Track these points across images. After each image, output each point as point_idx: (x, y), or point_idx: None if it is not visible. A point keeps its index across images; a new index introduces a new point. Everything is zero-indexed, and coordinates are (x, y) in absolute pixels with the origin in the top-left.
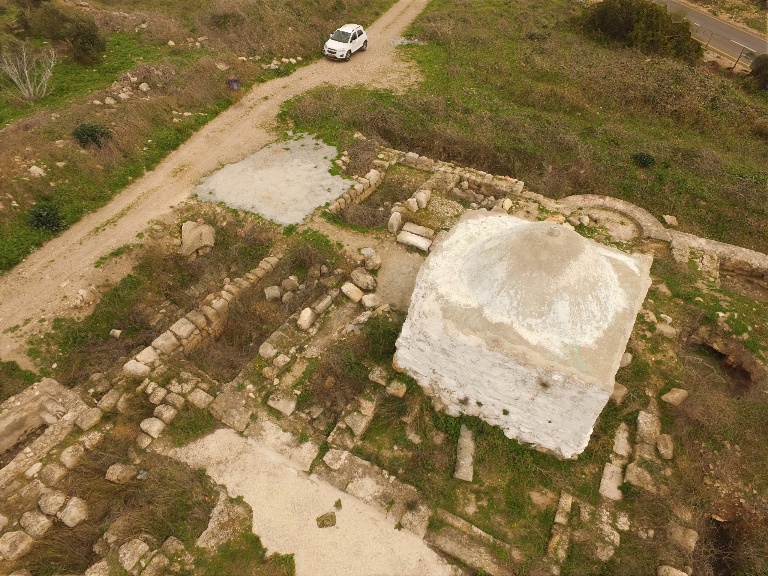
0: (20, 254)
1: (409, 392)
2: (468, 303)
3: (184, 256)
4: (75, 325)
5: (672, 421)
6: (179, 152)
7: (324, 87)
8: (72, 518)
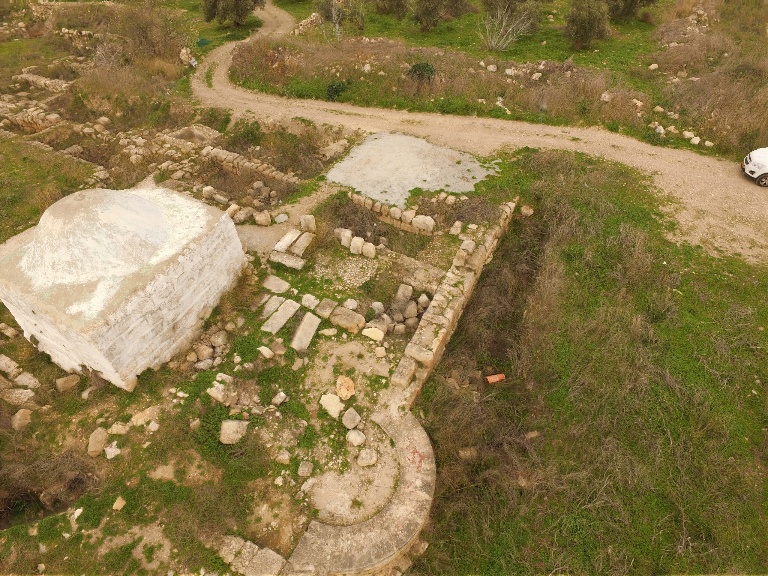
0: (308, 95)
1: None
2: None
3: (315, 150)
4: (256, 130)
5: (3, 408)
6: (441, 116)
7: (639, 172)
8: (132, 158)
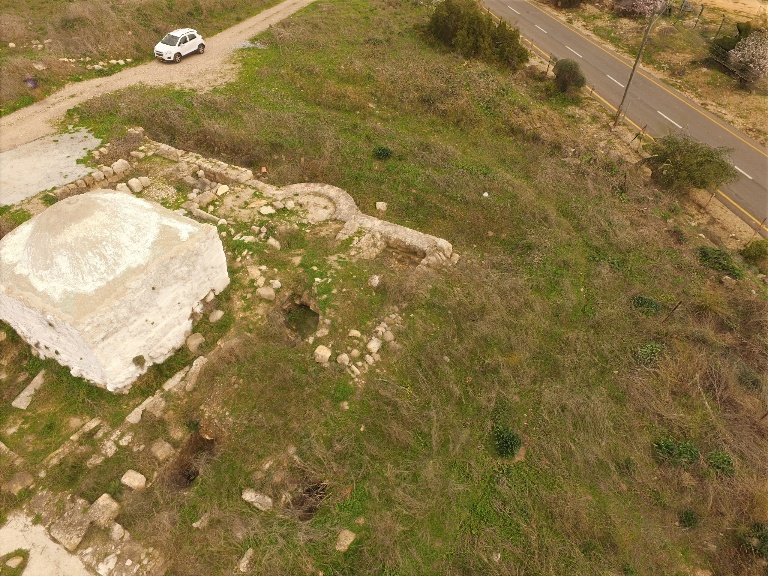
0: None
1: (5, 339)
2: (12, 260)
3: None
4: None
5: None
6: None
7: (135, 86)
8: None
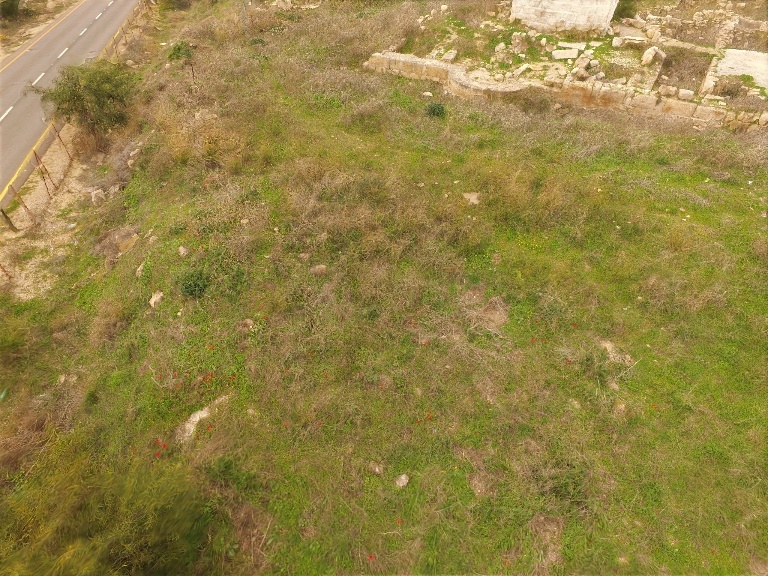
0: None
1: None
2: None
3: None
4: None
5: None
6: None
7: None
8: None
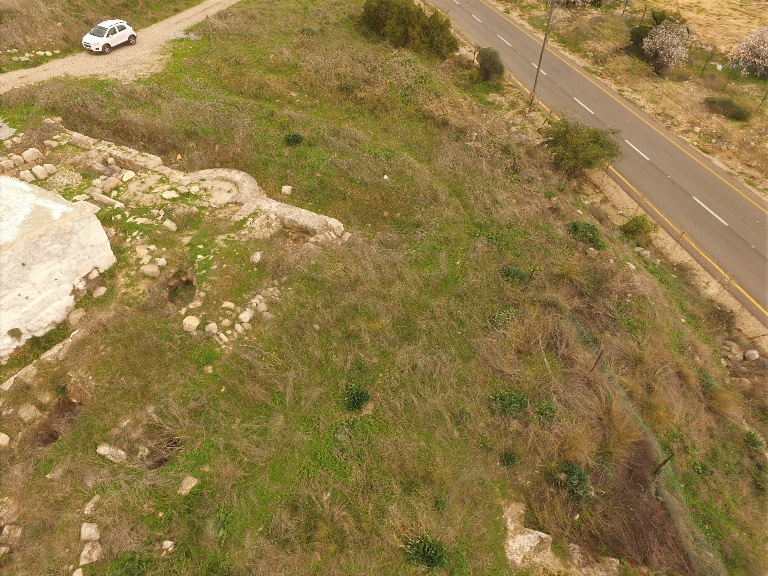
0: None
1: None
2: None
3: None
4: None
5: None
6: None
7: (60, 77)
8: None
